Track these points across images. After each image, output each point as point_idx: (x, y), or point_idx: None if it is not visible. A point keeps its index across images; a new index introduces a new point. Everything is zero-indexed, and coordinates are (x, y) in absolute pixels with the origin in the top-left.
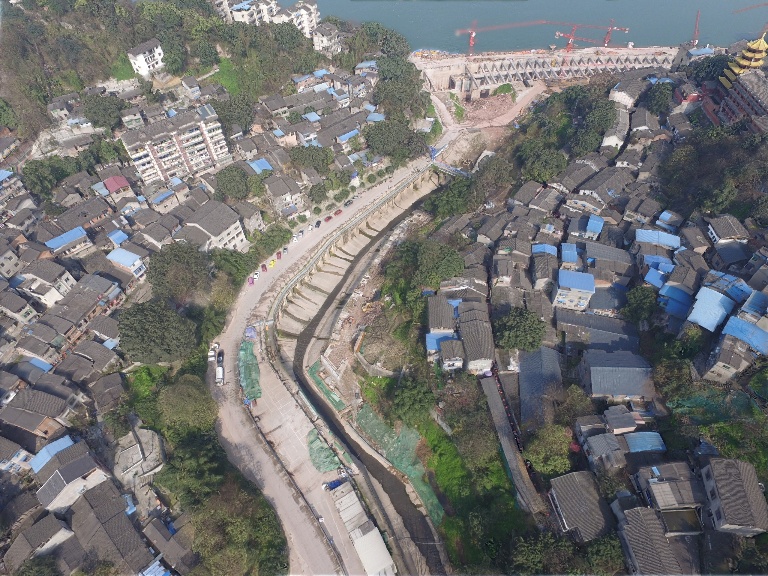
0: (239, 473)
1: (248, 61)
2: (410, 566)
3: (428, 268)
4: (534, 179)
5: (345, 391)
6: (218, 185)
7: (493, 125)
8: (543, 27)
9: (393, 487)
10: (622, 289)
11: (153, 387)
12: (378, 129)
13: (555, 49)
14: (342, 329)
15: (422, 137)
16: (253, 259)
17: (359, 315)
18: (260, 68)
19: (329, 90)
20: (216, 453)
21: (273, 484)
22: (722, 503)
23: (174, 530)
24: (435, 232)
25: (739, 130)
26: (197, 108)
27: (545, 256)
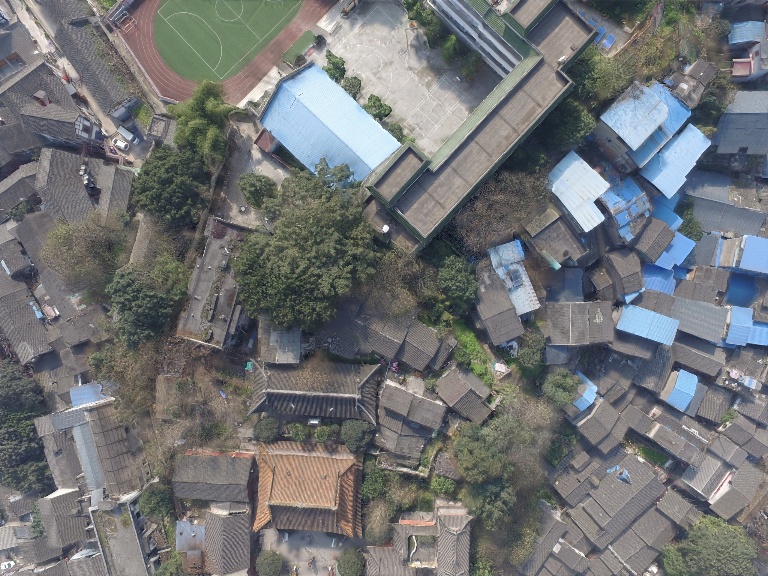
0: None
1: None
2: None
3: None
4: (725, 521)
5: None
6: None
7: None
8: None
9: None
10: (675, 266)
11: None
12: None
13: None
14: None
15: None
16: None
17: None
18: None
19: None
20: None
21: None
22: None
23: None
24: None
25: (469, 566)
26: None
27: None
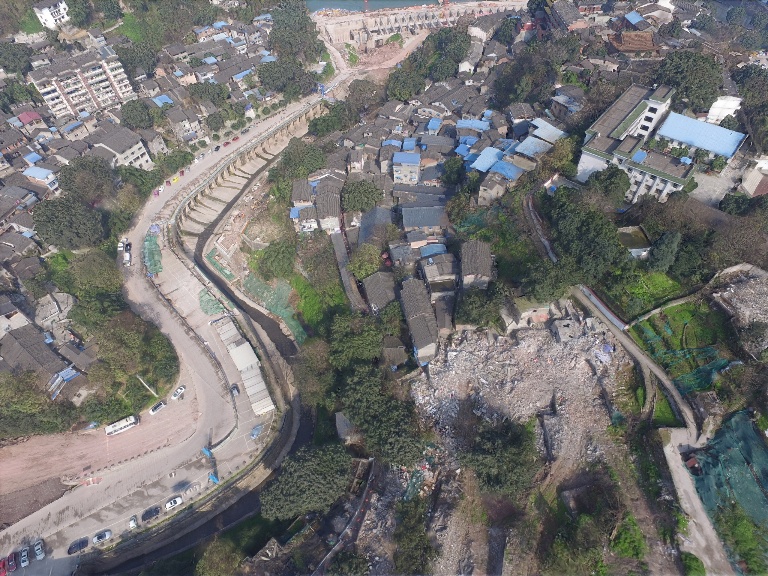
0: (140, 317)
1: (150, 14)
2: (278, 371)
3: (296, 162)
4: (397, 98)
5: (235, 266)
6: (122, 115)
7: (381, 68)
8: None
9: (270, 326)
10: None
11: (68, 267)
12: (267, 66)
13: None
14: (233, 222)
15: (312, 76)
16: (157, 175)
17: (249, 212)
18: (162, 21)
19: (228, 39)
20: (121, 305)
21: (169, 325)
22: (462, 265)
23: (84, 349)
24: None
25: None
26: (98, 49)
27: (388, 145)
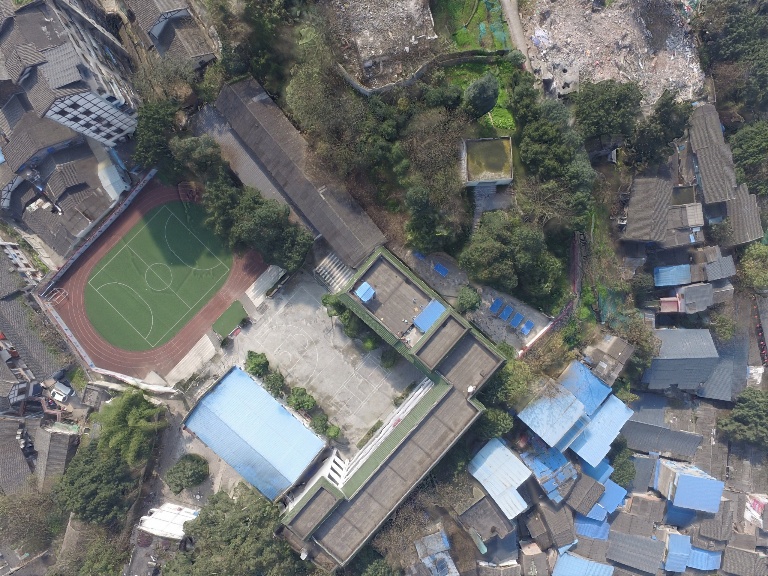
0: None
1: None
2: None
3: None
4: None
5: None
6: None
7: None
8: None
9: None
10: None
11: None
12: None
13: None
14: None
15: None
16: None
17: None
18: None
19: None
20: None
21: None
22: None
23: None
24: None
25: None
26: None
27: None
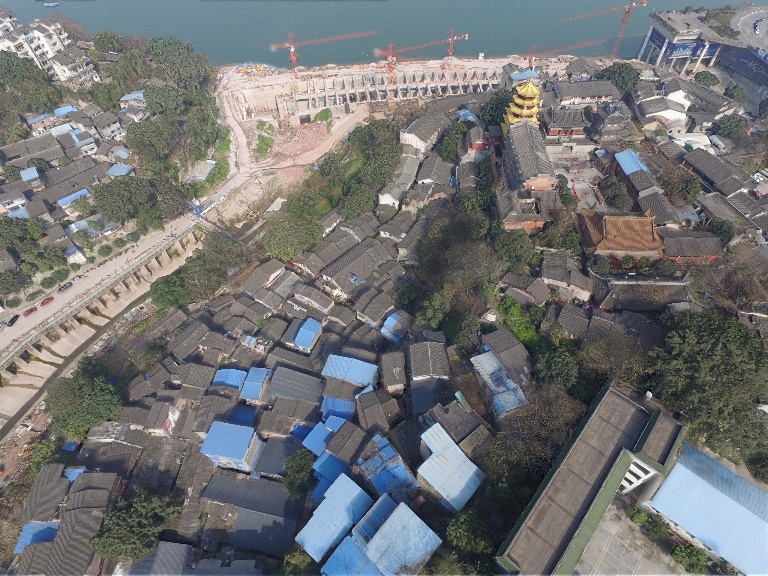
0: None
1: None
2: None
3: None
4: (277, 257)
5: None
6: None
7: (297, 163)
8: (401, 31)
9: None
10: None
11: None
12: (103, 191)
13: (406, 59)
14: None
15: (184, 190)
16: None
17: (14, 461)
18: None
19: (73, 132)
20: None
21: None
22: None
23: None
24: (140, 335)
25: (489, 205)
26: None
27: (212, 395)
